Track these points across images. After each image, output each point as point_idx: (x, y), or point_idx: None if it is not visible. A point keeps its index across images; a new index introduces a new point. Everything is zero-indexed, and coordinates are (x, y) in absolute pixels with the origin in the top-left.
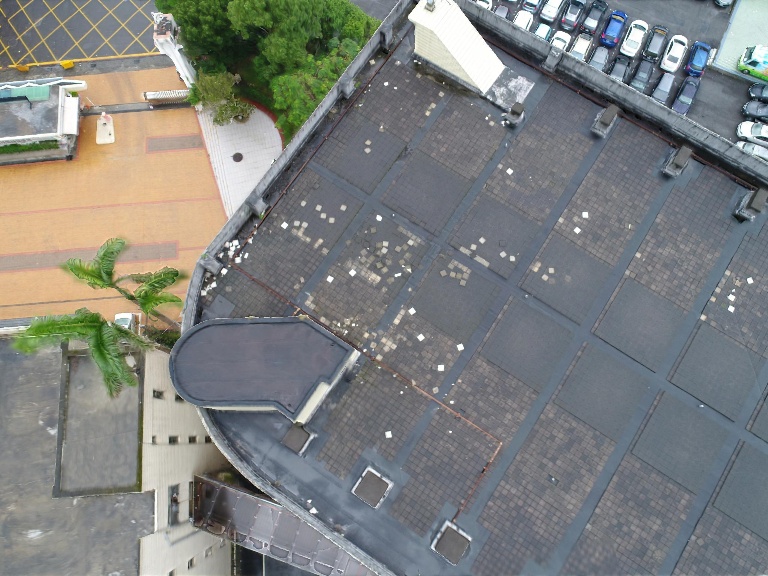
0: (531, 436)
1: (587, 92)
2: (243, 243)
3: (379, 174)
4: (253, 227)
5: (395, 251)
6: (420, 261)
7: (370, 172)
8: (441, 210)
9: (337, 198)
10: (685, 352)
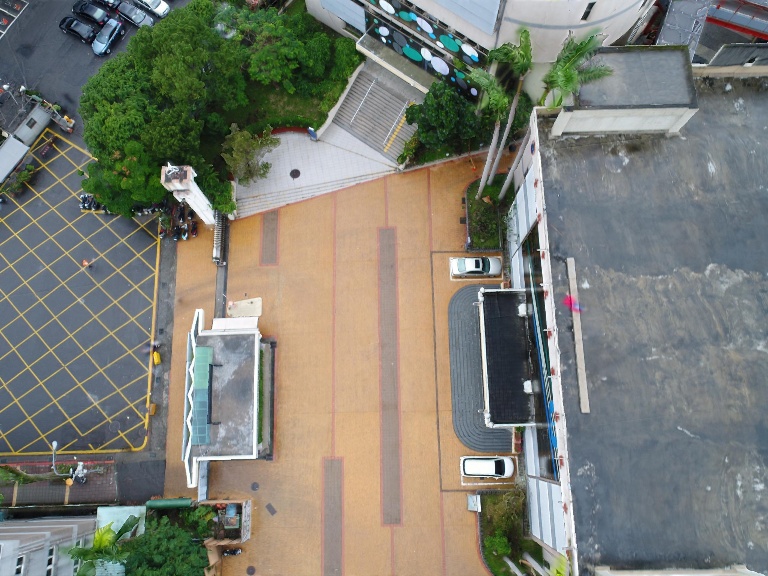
0: None
1: None
2: None
3: None
4: None
5: None
6: None
7: None
8: None
9: None
10: None
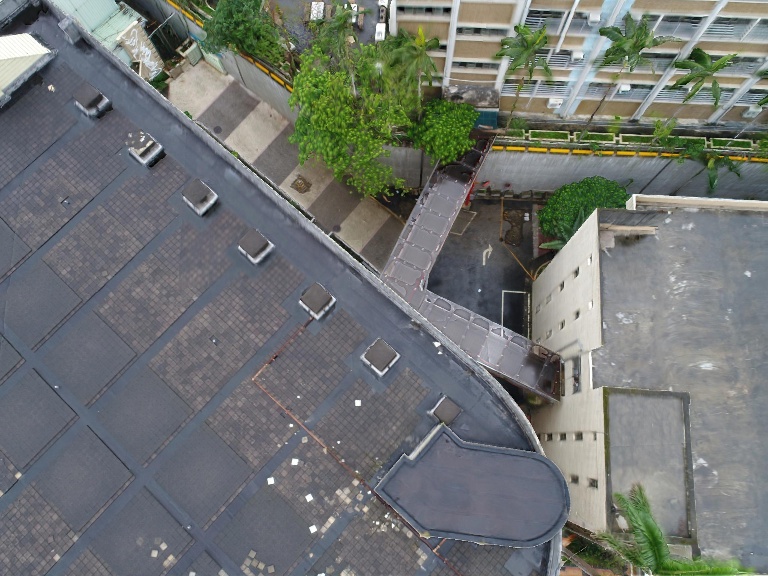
0: (224, 382)
1: None
2: None
3: None
4: None
5: None
6: None
7: None
8: None
9: None
10: (51, 442)
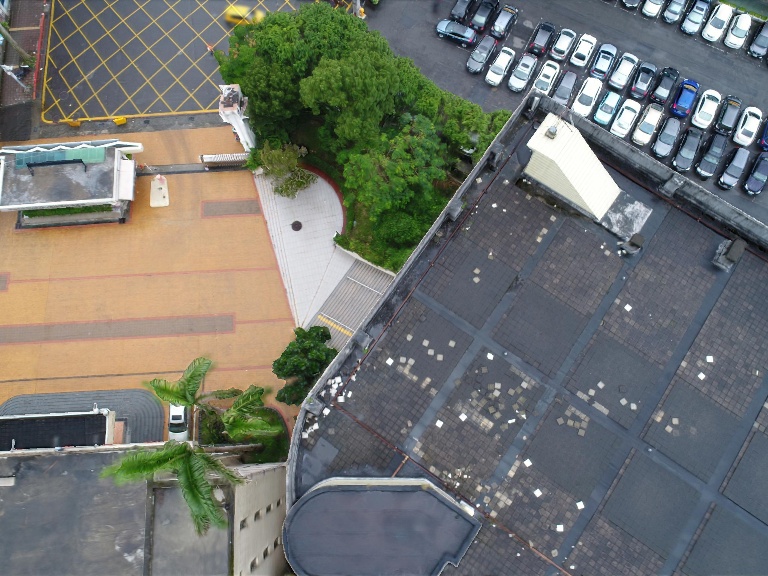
0: None
1: (707, 220)
2: (346, 380)
3: (489, 307)
4: (356, 362)
5: (508, 394)
6: (535, 406)
7: (479, 304)
8: (556, 349)
9: (445, 332)
10: None
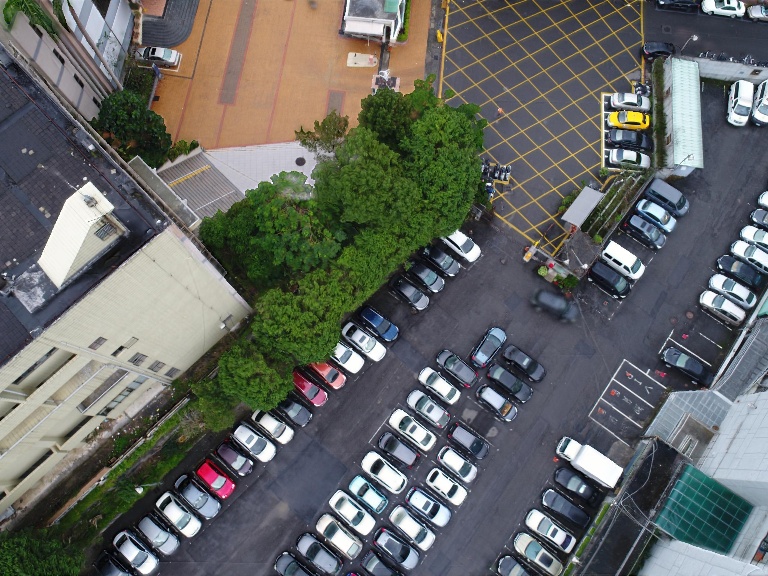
0: None
1: None
2: None
3: None
4: None
5: None
6: None
7: (3, 149)
8: None
9: None
10: None
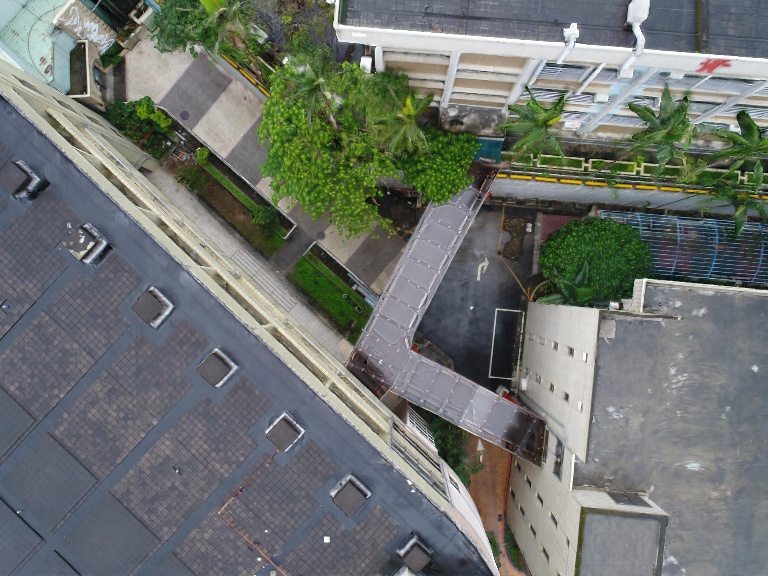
0: (189, 513)
1: None
2: None
3: None
4: None
5: None
6: None
7: None
8: None
9: None
10: (20, 565)
